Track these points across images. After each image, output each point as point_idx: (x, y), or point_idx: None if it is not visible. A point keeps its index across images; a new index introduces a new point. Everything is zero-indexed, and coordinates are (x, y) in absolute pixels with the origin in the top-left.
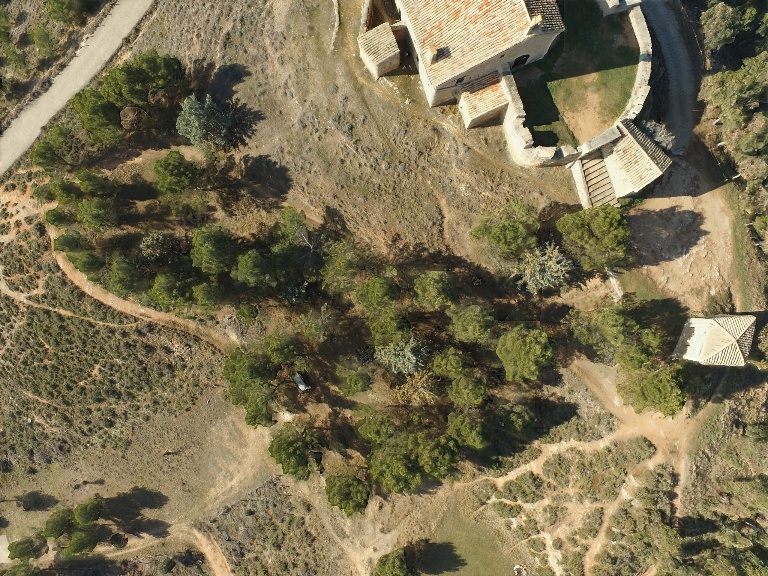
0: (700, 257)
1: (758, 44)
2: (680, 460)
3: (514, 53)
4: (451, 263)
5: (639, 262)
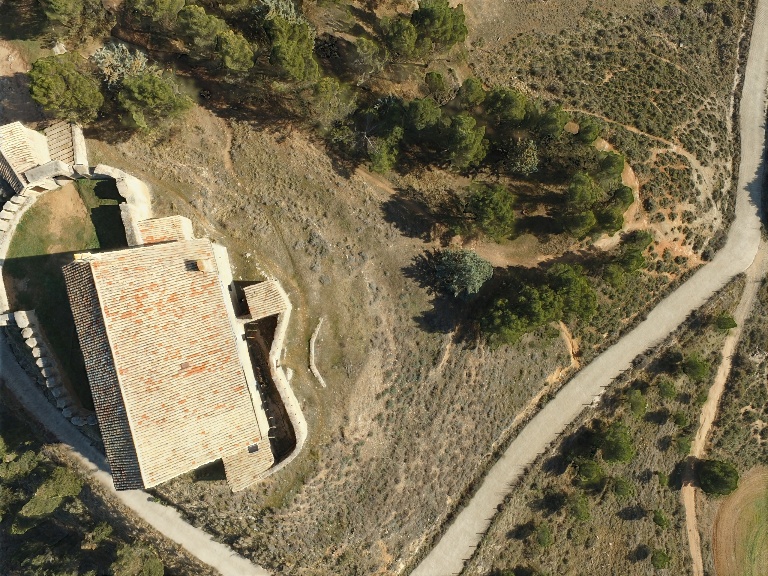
0: None
1: None
2: None
3: None
4: (229, 111)
5: None
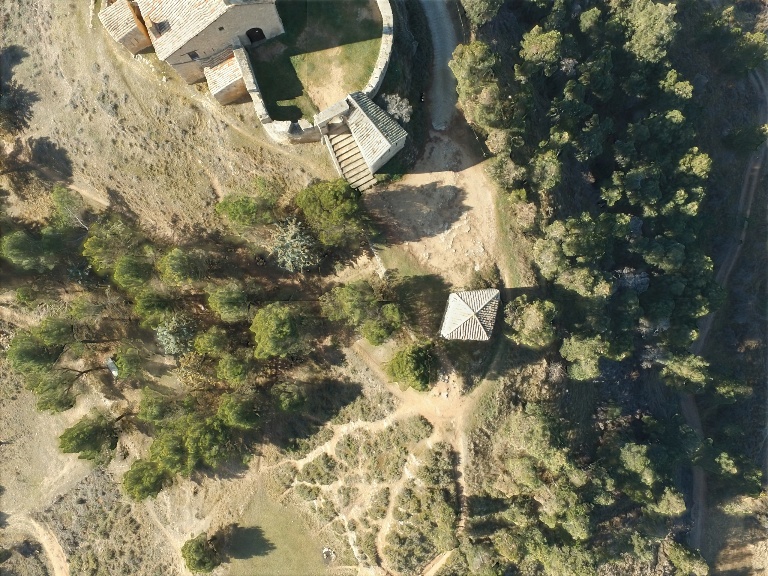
0: (463, 232)
1: (547, 20)
2: (458, 438)
3: (235, 26)
4: (231, 243)
5: (400, 238)
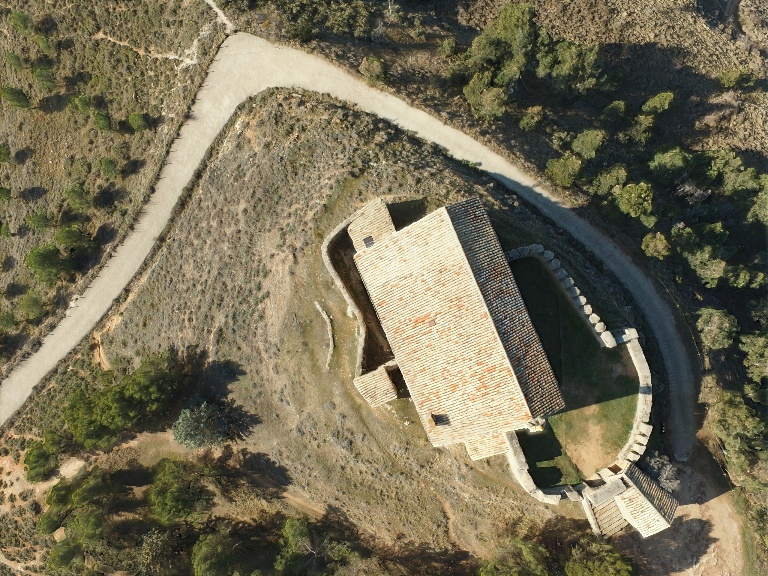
0: (711, 565)
1: (754, 308)
2: None
3: None
4: (458, 558)
5: (649, 575)
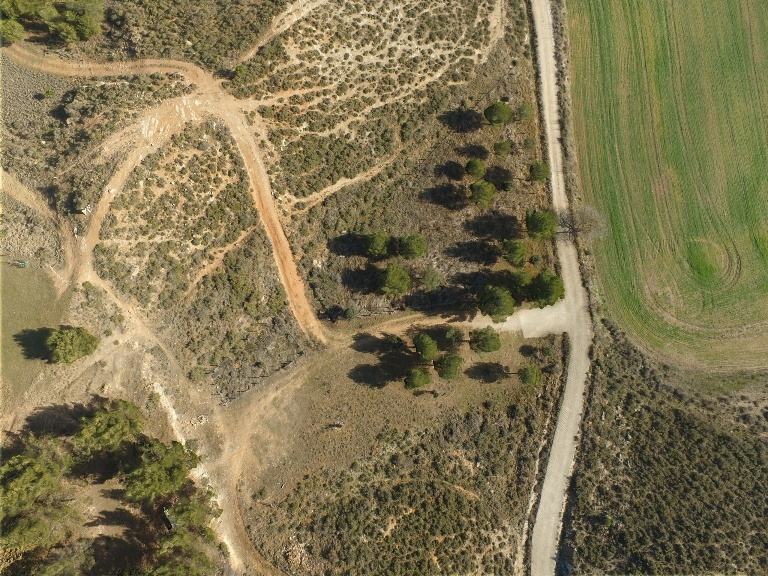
0: None
1: None
2: None
3: None
4: None
5: None
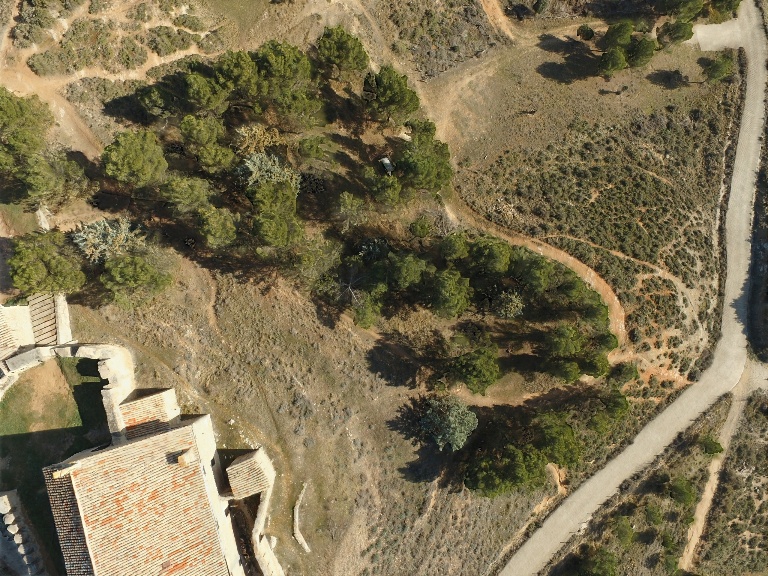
0: None
1: None
2: (5, 50)
3: None
4: (213, 262)
5: None
